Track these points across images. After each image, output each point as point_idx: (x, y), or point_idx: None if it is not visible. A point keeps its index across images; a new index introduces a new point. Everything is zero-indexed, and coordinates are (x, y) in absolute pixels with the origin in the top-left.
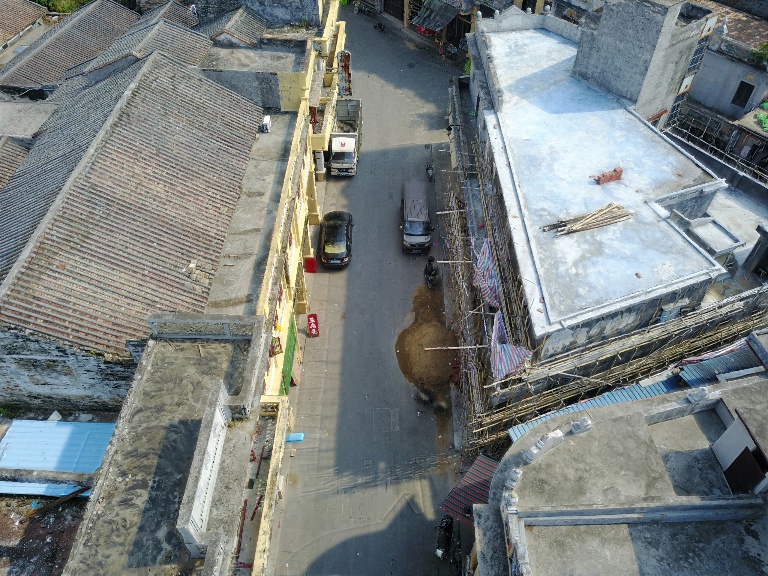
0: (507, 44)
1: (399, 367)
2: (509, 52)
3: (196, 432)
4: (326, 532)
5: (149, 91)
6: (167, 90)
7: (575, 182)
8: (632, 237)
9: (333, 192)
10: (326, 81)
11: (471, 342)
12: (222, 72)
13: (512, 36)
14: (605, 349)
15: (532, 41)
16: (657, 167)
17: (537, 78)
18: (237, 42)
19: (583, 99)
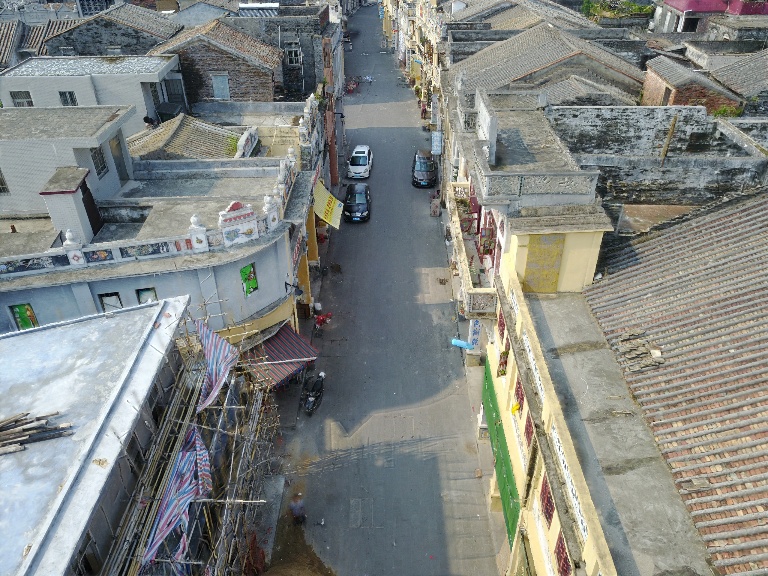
0: None
1: None
2: None
3: (511, 161)
4: (427, 407)
5: None
6: None
7: None
8: None
9: None
10: None
11: None
12: None
13: None
14: None
15: None
16: None
17: None
18: None
19: None
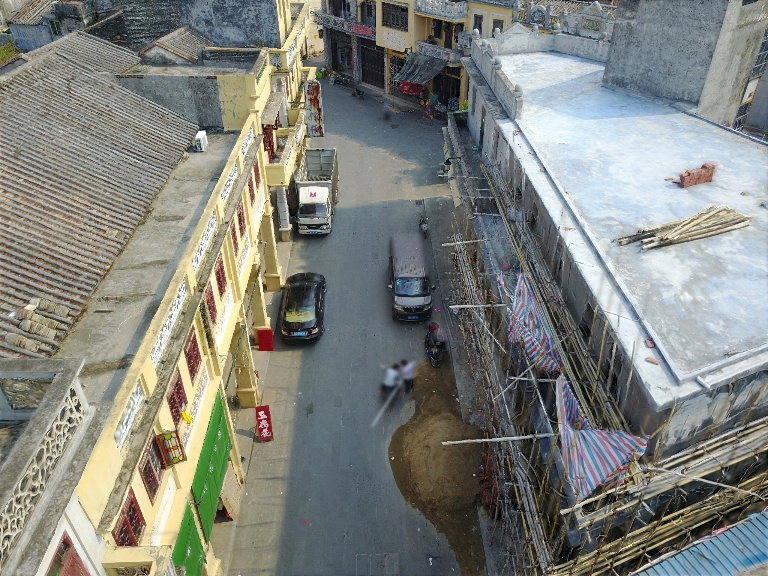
0: (513, 63)
1: (395, 483)
2: (517, 69)
3: None
4: None
5: (28, 88)
6: (57, 91)
7: (646, 186)
8: (763, 249)
9: (301, 253)
10: (291, 119)
11: (516, 433)
12: (143, 79)
13: (517, 57)
14: (762, 433)
15: (543, 60)
16: (757, 167)
17: (558, 89)
18: (172, 58)
19: (625, 105)
